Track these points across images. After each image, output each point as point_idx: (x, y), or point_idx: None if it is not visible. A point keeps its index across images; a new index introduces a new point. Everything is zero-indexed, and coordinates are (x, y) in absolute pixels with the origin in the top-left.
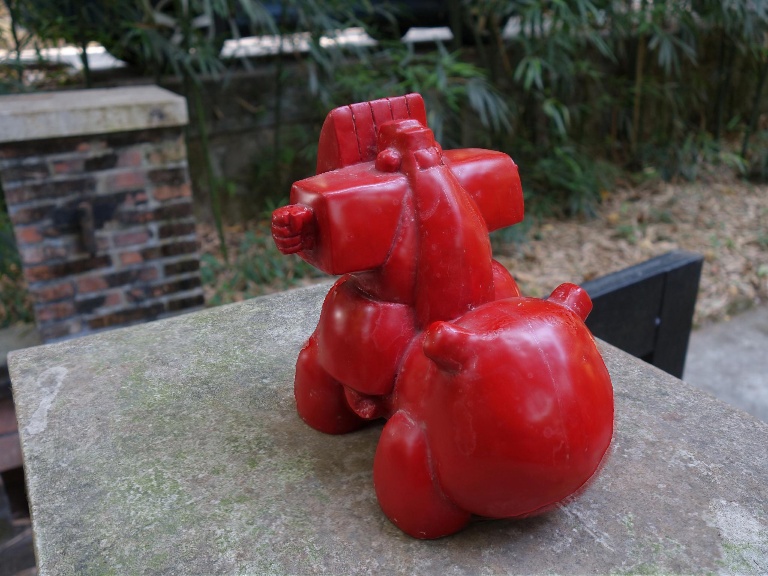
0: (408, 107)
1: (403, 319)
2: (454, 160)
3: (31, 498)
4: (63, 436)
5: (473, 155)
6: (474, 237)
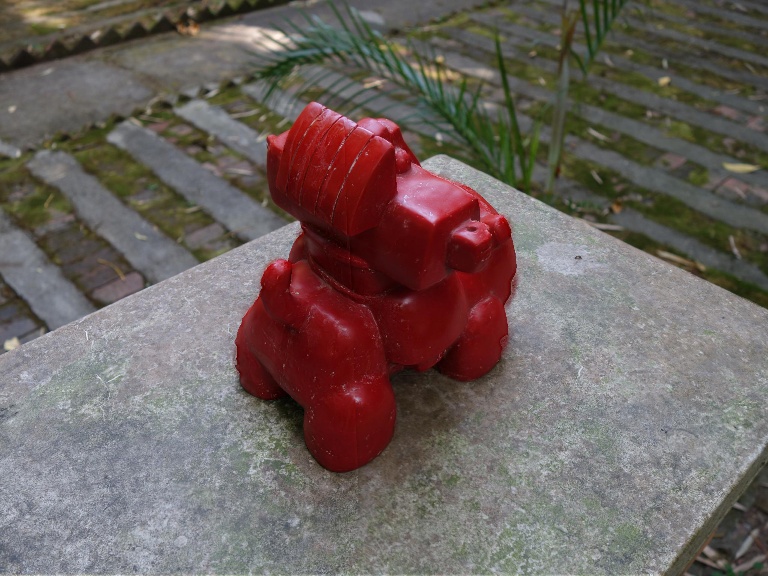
0: None
1: None
2: None
3: None
4: None
5: None
6: None
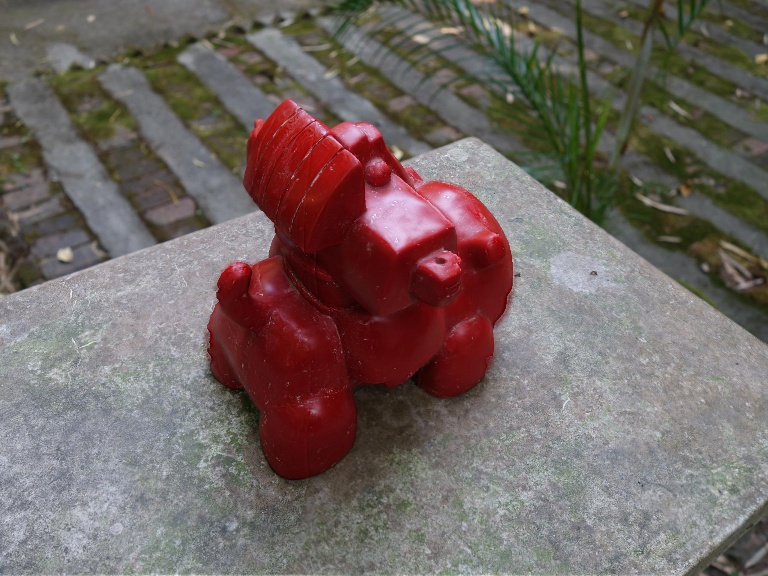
0: None
1: None
2: None
3: None
4: None
5: None
6: None
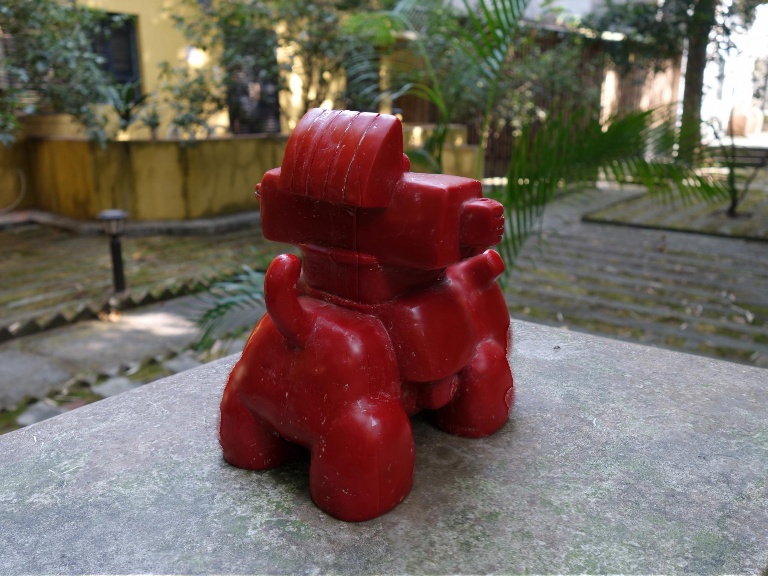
0: None
1: None
2: None
3: None
4: None
5: None
6: None
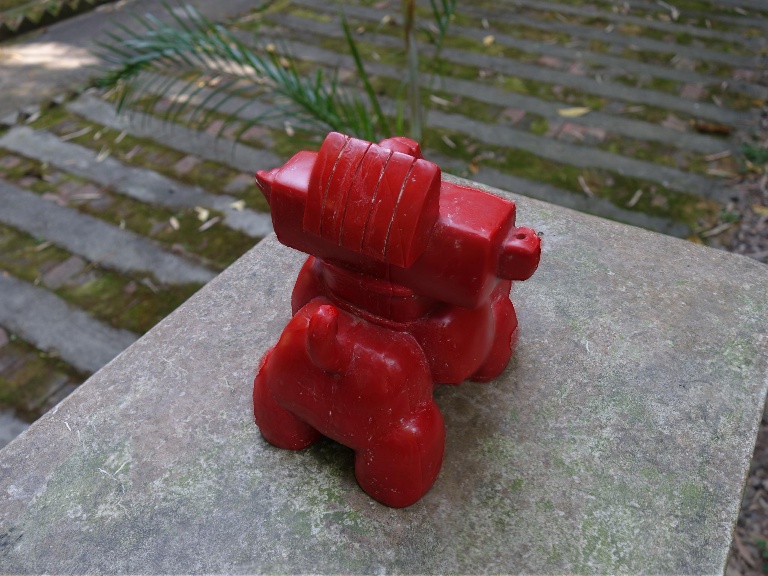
0: None
1: None
2: None
3: None
4: None
5: None
6: None
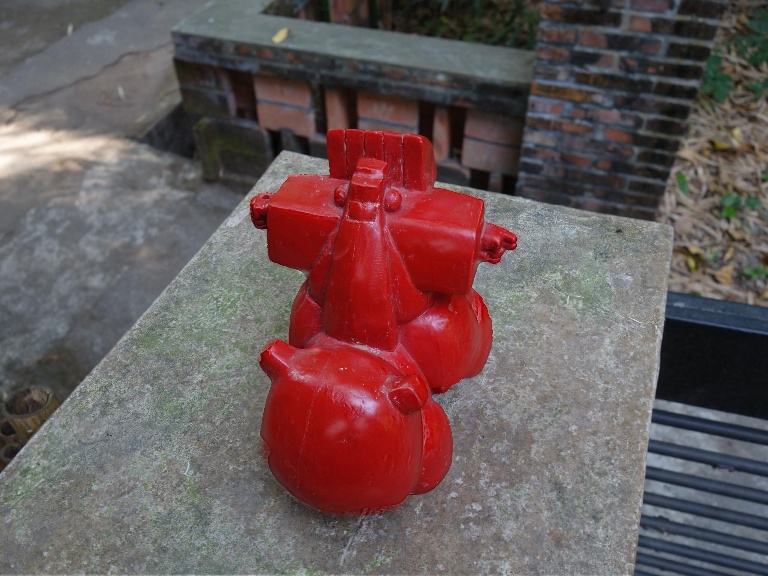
0: (404, 147)
1: (316, 316)
2: (408, 216)
3: (182, 270)
4: (235, 238)
5: (438, 217)
6: (366, 293)
